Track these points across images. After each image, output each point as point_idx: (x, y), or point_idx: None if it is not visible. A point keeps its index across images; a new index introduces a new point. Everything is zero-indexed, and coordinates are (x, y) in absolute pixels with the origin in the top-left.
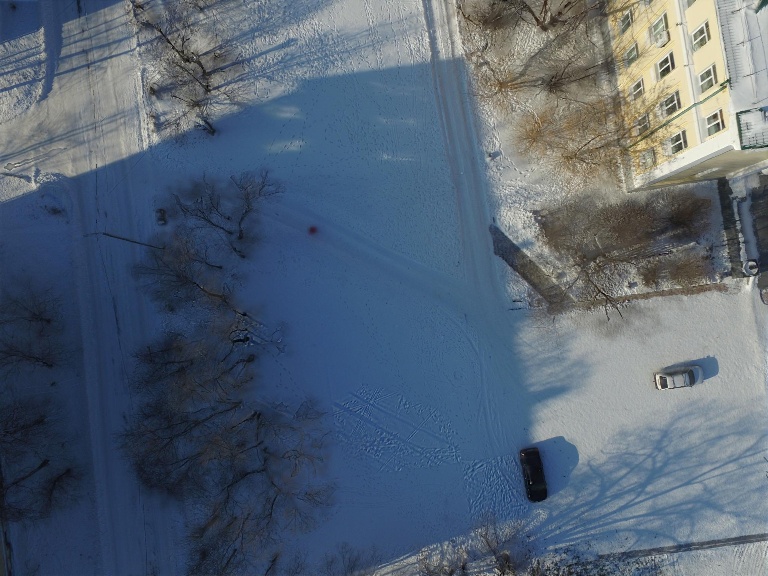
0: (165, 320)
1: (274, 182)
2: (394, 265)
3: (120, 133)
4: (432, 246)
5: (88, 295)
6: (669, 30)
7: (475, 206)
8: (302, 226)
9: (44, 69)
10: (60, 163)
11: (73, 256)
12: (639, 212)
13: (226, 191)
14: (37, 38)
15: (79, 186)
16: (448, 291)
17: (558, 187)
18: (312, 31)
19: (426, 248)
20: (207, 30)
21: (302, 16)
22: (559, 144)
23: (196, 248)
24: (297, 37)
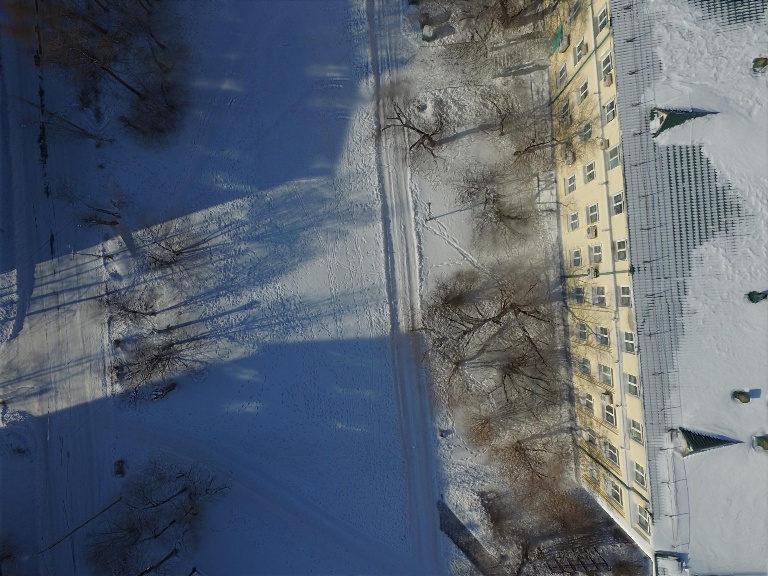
0: (118, 568)
1: (230, 440)
2: (341, 533)
3: (85, 376)
4: (379, 519)
5: (48, 533)
6: (613, 394)
7: (424, 481)
8: (255, 486)
9: (15, 310)
10: (27, 402)
11: (35, 495)
12: (587, 502)
13: (184, 444)
14: (10, 278)
15: (44, 425)
16: (392, 563)
17: (508, 470)
18: (275, 295)
19: (373, 520)
20: (173, 285)
21: (266, 279)
22: (512, 426)
23: (147, 521)
24: (260, 300)
